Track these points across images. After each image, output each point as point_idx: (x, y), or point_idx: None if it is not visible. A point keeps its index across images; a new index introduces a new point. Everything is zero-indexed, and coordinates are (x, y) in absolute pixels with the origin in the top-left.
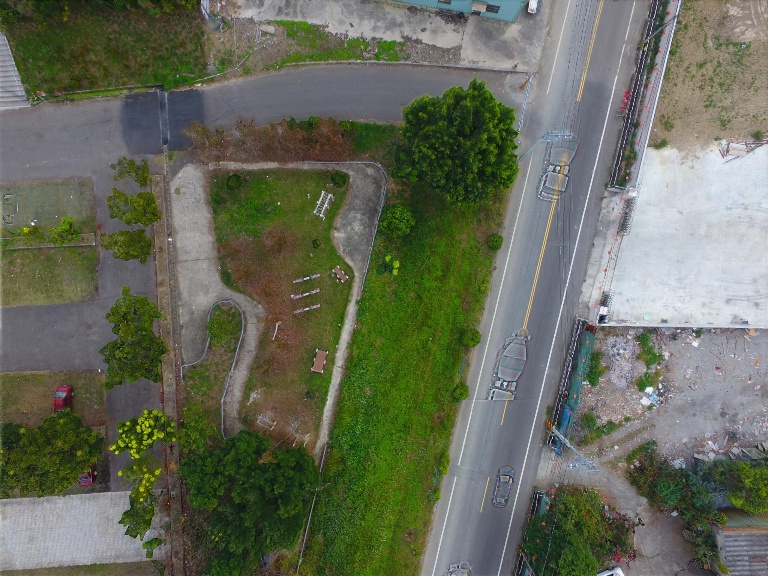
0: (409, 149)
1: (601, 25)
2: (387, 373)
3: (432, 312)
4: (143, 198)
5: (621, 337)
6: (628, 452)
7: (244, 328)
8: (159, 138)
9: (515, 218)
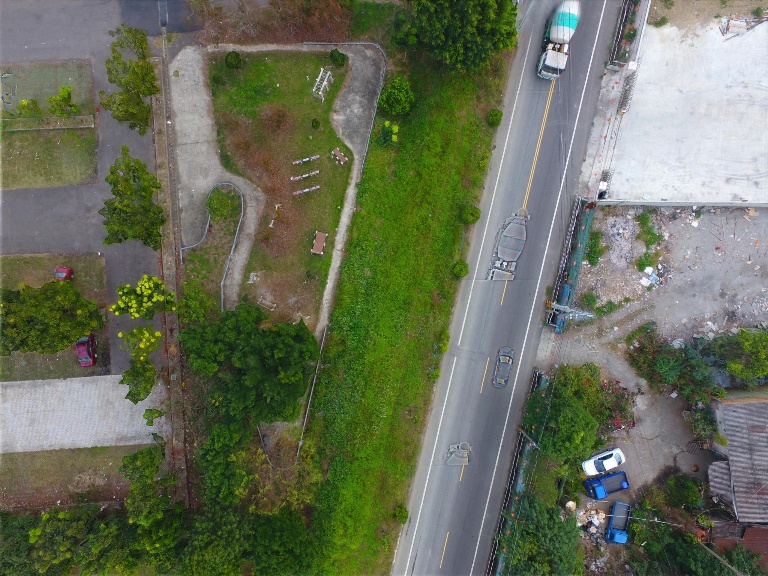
0: (408, 11)
1: None
2: (387, 252)
3: (432, 188)
4: (142, 67)
5: (621, 217)
6: (628, 333)
7: (244, 211)
8: (157, 20)
9: (515, 97)
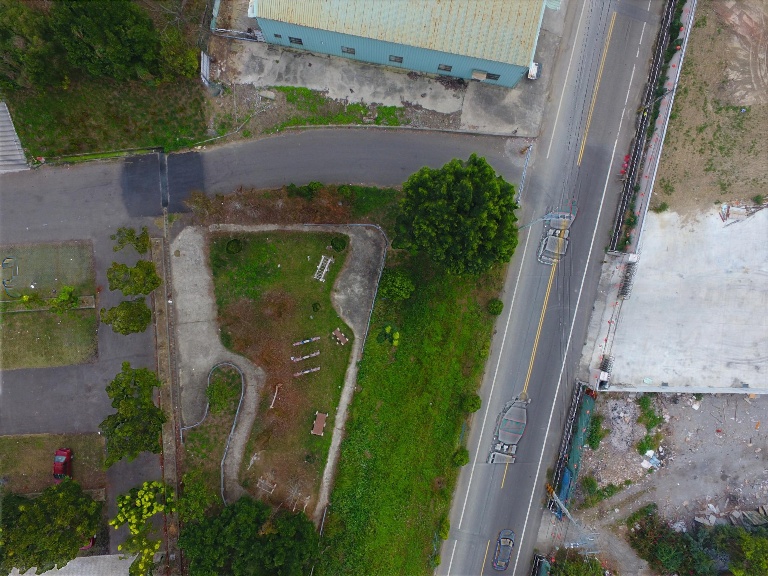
0: (409, 222)
1: (601, 89)
2: (387, 437)
3: (432, 377)
4: (143, 267)
5: (621, 400)
6: (629, 515)
7: (244, 390)
8: (159, 200)
9: (515, 282)
